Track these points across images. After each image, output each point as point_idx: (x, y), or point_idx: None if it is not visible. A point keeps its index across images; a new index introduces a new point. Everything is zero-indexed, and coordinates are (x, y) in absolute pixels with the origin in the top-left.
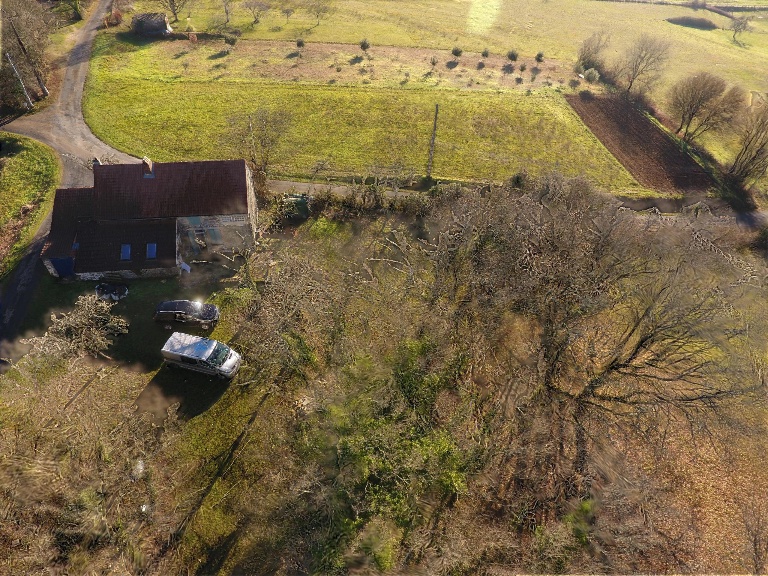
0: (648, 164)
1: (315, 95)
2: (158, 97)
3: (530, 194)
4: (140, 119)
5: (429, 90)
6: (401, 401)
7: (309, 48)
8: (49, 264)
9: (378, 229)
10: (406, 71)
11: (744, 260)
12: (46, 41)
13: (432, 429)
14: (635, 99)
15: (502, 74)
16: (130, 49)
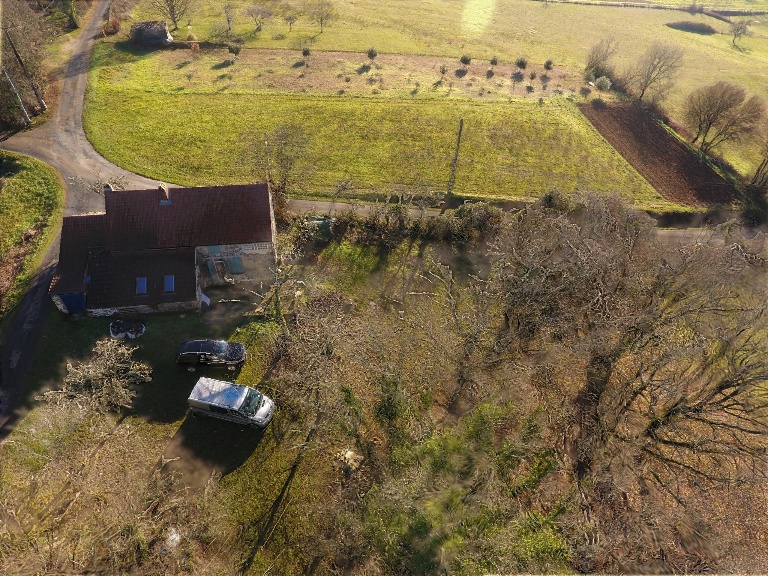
0: (669, 176)
1: (325, 107)
2: (162, 110)
3: (565, 214)
4: (145, 134)
5: (441, 100)
6: (508, 498)
7: (315, 57)
8: (58, 300)
9: (405, 252)
10: (415, 80)
11: None
12: (43, 53)
13: (542, 528)
14: (648, 107)
15: (512, 82)
16: (130, 59)
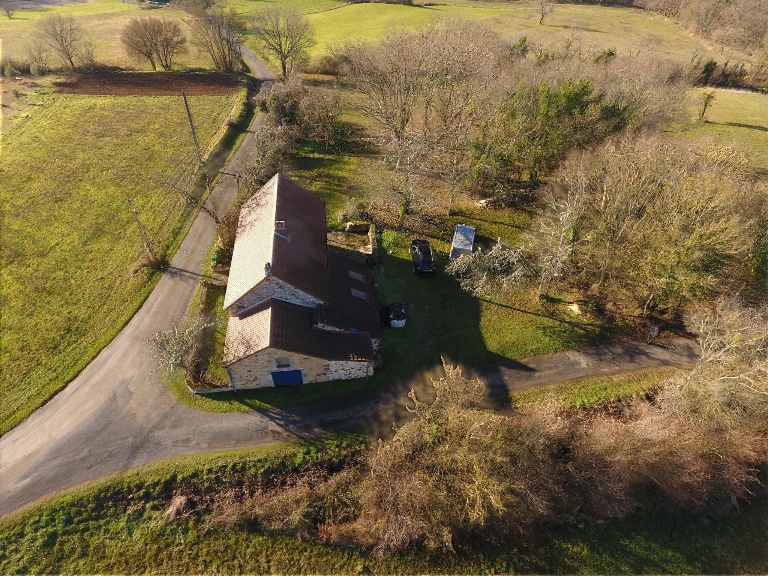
0: (201, 88)
1: None
2: None
3: None
4: None
5: None
6: None
7: None
8: None
9: None
10: None
11: (313, 89)
12: None
13: None
14: (93, 68)
15: None
16: None
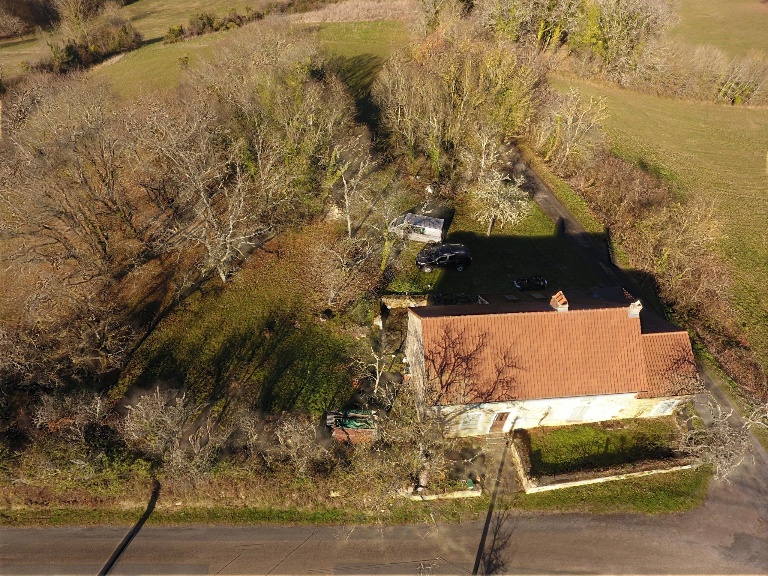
0: None
1: None
2: None
3: None
4: None
5: None
6: None
7: None
8: None
9: None
10: None
11: None
12: None
13: None
14: None
15: None
16: None
